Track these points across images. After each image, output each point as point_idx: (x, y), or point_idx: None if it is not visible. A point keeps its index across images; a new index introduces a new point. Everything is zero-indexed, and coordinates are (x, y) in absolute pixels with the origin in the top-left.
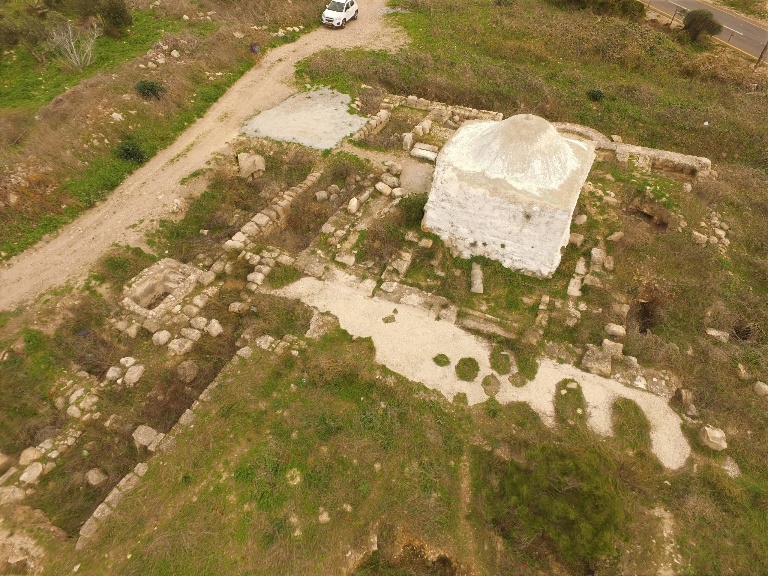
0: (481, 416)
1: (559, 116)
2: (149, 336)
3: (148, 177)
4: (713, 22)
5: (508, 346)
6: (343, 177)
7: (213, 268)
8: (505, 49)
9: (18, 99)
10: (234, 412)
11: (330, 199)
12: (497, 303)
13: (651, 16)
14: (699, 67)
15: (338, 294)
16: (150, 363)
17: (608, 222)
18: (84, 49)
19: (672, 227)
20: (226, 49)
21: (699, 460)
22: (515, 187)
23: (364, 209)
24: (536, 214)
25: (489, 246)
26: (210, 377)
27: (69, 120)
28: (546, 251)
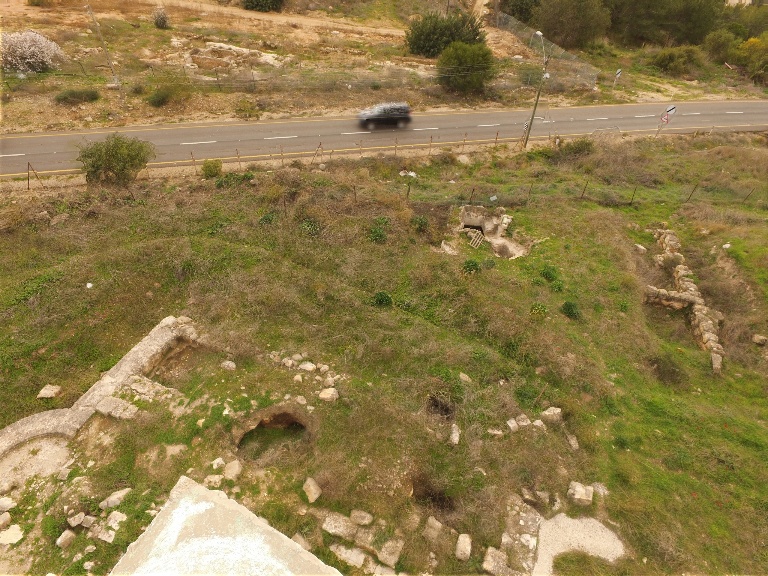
0: None
1: None
2: None
3: None
4: None
5: None
6: None
7: None
8: None
9: None
10: None
11: None
12: None
13: None
14: None
15: None
16: None
17: (276, 488)
18: None
19: (299, 412)
20: None
21: (603, 516)
22: None
23: None
24: None
25: None
26: None
27: None
28: None
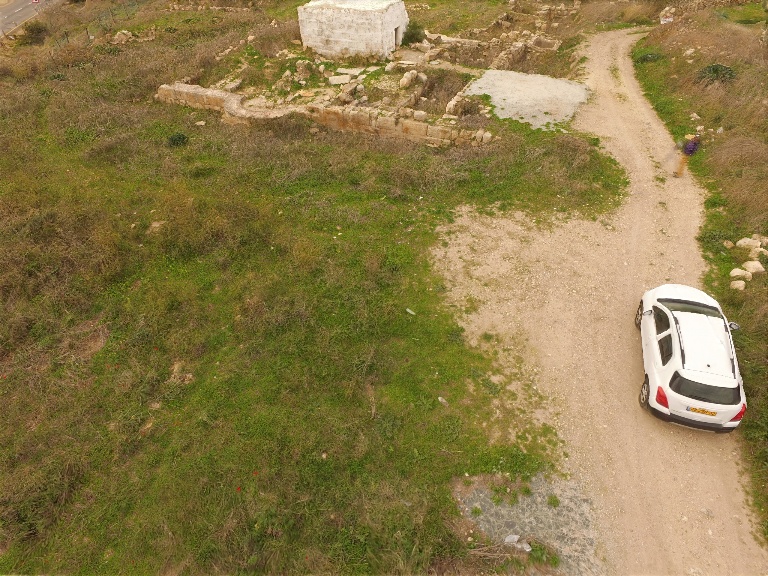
0: None
1: None
2: None
3: (618, 62)
4: None
5: None
6: None
7: None
8: None
9: None
10: None
11: None
12: None
13: None
14: None
15: None
16: None
17: None
18: None
19: None
20: None
21: None
22: None
23: None
24: None
25: None
26: None
27: None
28: None
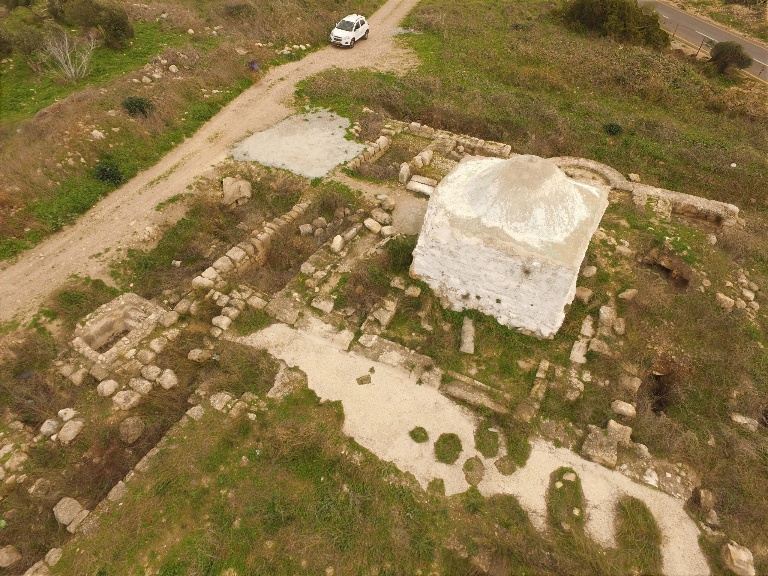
0: (459, 511)
1: (572, 150)
2: (96, 384)
3: (123, 200)
4: (742, 55)
5: (497, 421)
6: (332, 209)
7: (177, 307)
8: (519, 76)
9: (5, 110)
10: (171, 489)
11: (315, 234)
12: (489, 366)
13: (676, 46)
14: (727, 103)
15: (310, 346)
16: (91, 417)
17: (620, 276)
18: (80, 61)
19: (693, 285)
20: (226, 66)
21: None
22: (514, 238)
23: (349, 248)
24: (536, 270)
25: (483, 300)
26: (155, 439)
27: (45, 136)
28: (547, 310)
